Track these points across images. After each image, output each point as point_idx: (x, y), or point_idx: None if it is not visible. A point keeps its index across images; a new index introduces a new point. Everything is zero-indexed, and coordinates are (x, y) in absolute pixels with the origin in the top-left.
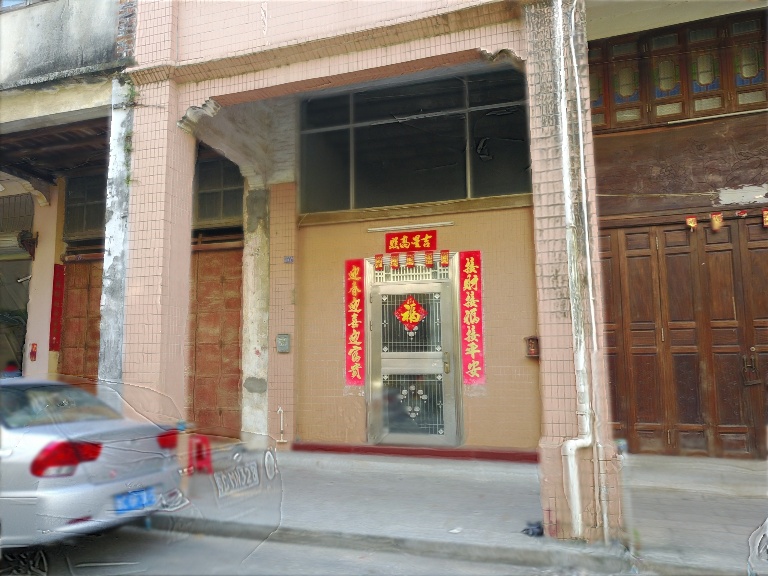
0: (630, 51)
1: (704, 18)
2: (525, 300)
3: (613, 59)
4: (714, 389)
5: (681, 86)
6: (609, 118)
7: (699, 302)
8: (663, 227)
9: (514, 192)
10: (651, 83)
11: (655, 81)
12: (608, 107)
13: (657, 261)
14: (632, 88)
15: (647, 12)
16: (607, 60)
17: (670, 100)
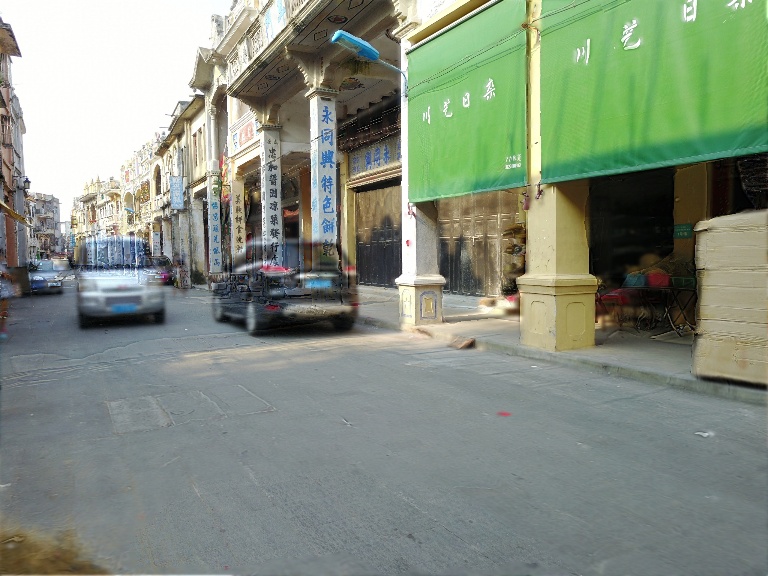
0: None
1: None
2: None
3: None
4: None
5: None
6: None
7: None
8: None
9: None
10: None
11: None
12: None
13: None
14: None
15: None
16: None
17: None
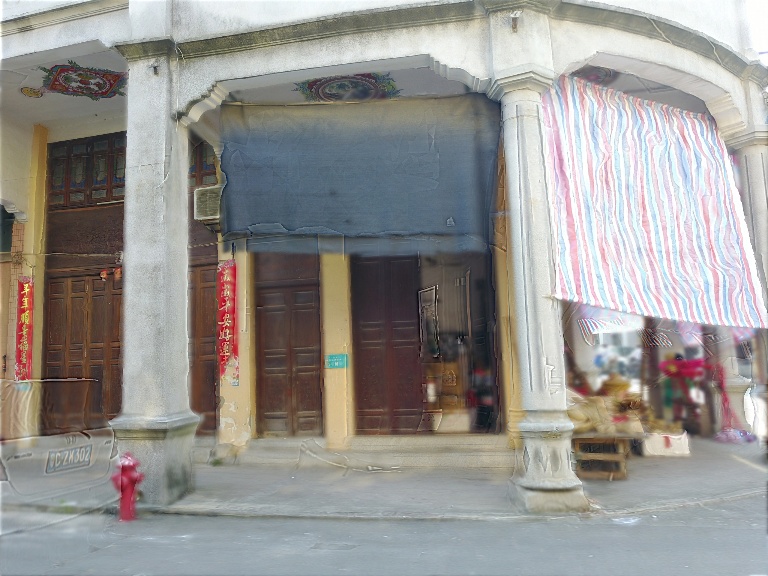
0: (83, 151)
1: (125, 130)
2: (6, 329)
3: (72, 156)
4: (109, 389)
5: (107, 178)
6: (66, 199)
7: (106, 330)
8: (93, 277)
9: (7, 250)
10: (90, 175)
11: (93, 174)
12: (66, 191)
13: (87, 301)
14: (82, 177)
15: (91, 124)
16: (68, 156)
17: (101, 187)
